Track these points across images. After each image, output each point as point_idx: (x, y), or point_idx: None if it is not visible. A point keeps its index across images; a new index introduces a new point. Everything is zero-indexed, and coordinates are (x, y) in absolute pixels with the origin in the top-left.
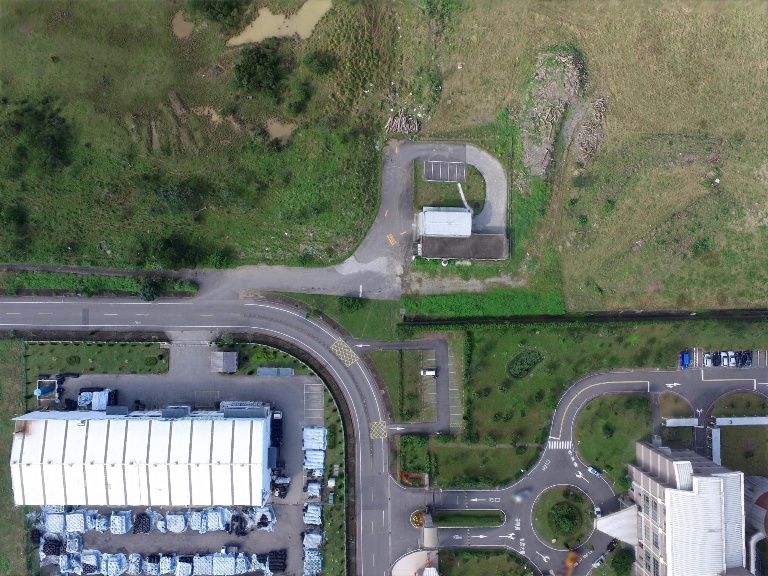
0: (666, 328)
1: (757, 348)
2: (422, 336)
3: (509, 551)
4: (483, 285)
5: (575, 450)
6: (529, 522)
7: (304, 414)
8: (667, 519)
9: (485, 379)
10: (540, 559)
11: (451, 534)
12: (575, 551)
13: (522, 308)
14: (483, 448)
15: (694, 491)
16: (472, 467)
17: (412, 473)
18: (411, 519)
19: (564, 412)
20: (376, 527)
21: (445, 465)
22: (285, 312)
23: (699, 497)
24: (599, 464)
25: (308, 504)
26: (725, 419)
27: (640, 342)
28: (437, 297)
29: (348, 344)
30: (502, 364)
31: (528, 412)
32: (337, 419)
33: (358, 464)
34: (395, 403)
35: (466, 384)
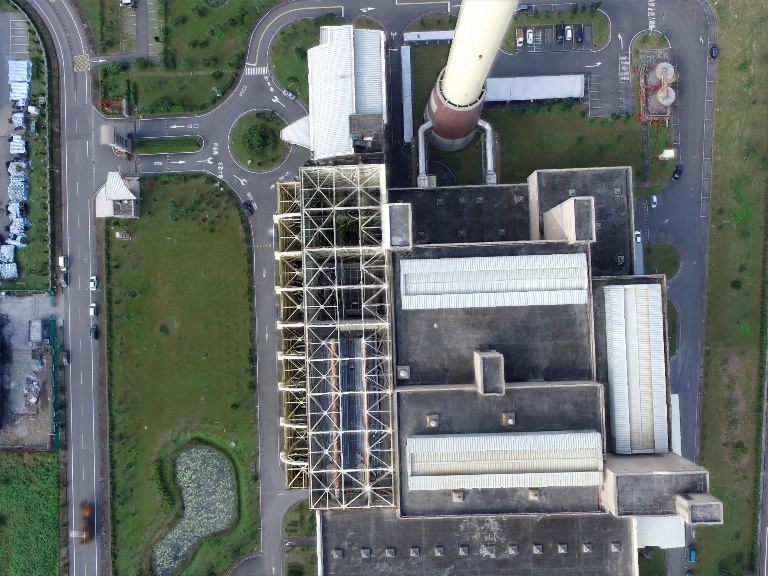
0: None
1: None
2: None
3: (207, 175)
4: None
5: (271, 75)
6: (226, 146)
7: (10, 49)
8: (309, 78)
9: (182, 8)
10: (238, 182)
11: (152, 161)
12: (271, 173)
13: None
14: (181, 75)
15: None
16: (171, 94)
17: (111, 100)
18: (113, 147)
19: (260, 39)
20: (80, 156)
21: (145, 93)
22: None
23: (332, 46)
24: (294, 88)
25: (14, 135)
26: (412, 33)
27: None
28: None
29: None
30: None
31: (224, 39)
32: None
33: (63, 96)
34: (97, 36)
35: (160, 9)
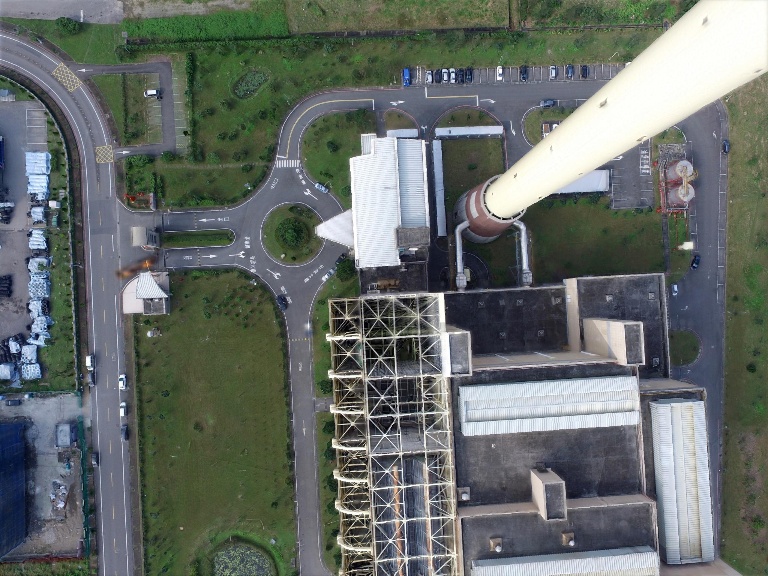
0: (389, 47)
1: (478, 65)
2: (145, 59)
3: (240, 269)
4: (206, 8)
5: (303, 168)
6: (258, 240)
7: (27, 140)
8: (352, 187)
9: (210, 100)
10: (271, 276)
11: (181, 255)
12: (305, 267)
13: (245, 29)
14: (210, 168)
15: (371, 152)
16: (200, 187)
17: (138, 193)
18: None
19: (290, 131)
20: (105, 251)
21: (172, 186)
22: (4, 38)
23: (375, 157)
24: (326, 181)
25: (33, 229)
26: (444, 129)
27: (363, 61)
28: (159, 19)
29: (70, 69)
30: (226, 84)
31: (254, 131)
32: (59, 141)
33: (85, 189)
34: (120, 127)
35: None
